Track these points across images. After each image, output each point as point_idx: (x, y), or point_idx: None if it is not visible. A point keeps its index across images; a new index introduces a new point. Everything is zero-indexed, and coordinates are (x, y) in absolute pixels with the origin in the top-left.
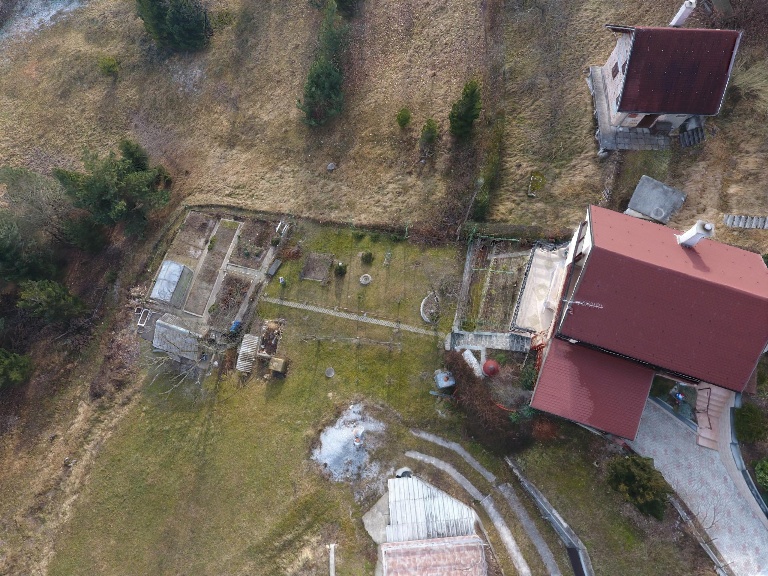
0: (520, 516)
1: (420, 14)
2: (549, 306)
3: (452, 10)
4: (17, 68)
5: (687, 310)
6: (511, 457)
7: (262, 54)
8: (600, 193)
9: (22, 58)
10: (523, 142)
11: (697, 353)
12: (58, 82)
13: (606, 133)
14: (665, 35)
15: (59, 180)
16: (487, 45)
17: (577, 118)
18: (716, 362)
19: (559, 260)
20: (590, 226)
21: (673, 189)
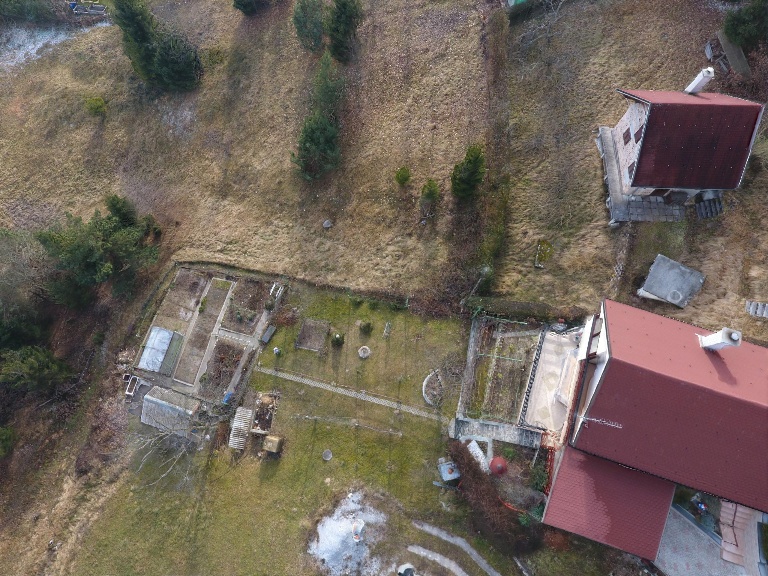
0: None
1: (419, 61)
2: (560, 400)
3: (453, 58)
4: (2, 105)
5: (713, 427)
6: (520, 558)
7: (255, 97)
8: (612, 268)
9: (7, 94)
10: (529, 207)
11: (723, 472)
12: (44, 121)
13: (618, 203)
14: (682, 110)
15: (41, 243)
16: (490, 100)
17: (586, 183)
18: (744, 482)
19: (570, 345)
20: (606, 329)
21: (691, 270)
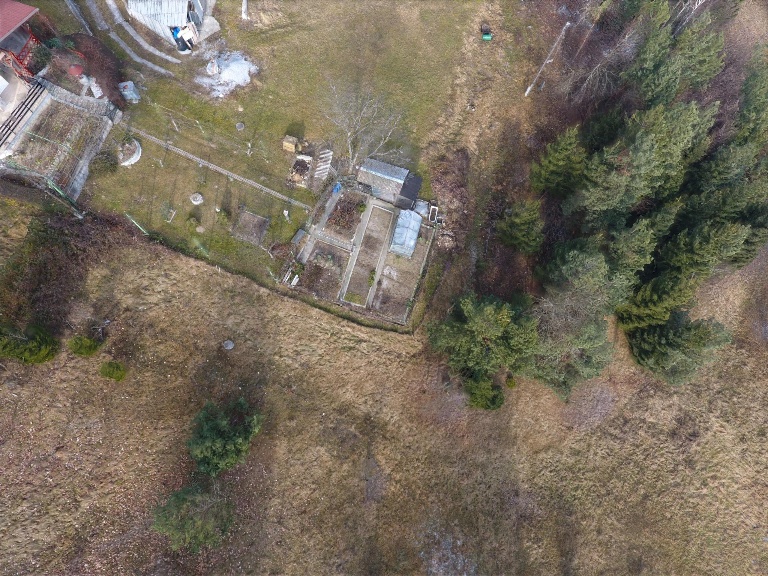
0: (96, 9)
1: None
2: None
3: None
4: None
5: None
6: None
7: None
8: None
9: None
10: None
11: None
12: None
13: None
14: None
15: None
16: None
17: None
18: None
19: None
20: None
21: None
